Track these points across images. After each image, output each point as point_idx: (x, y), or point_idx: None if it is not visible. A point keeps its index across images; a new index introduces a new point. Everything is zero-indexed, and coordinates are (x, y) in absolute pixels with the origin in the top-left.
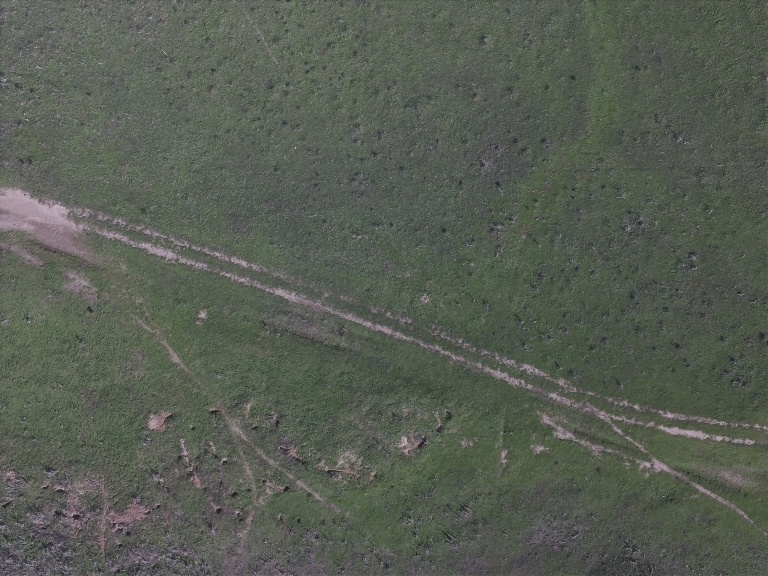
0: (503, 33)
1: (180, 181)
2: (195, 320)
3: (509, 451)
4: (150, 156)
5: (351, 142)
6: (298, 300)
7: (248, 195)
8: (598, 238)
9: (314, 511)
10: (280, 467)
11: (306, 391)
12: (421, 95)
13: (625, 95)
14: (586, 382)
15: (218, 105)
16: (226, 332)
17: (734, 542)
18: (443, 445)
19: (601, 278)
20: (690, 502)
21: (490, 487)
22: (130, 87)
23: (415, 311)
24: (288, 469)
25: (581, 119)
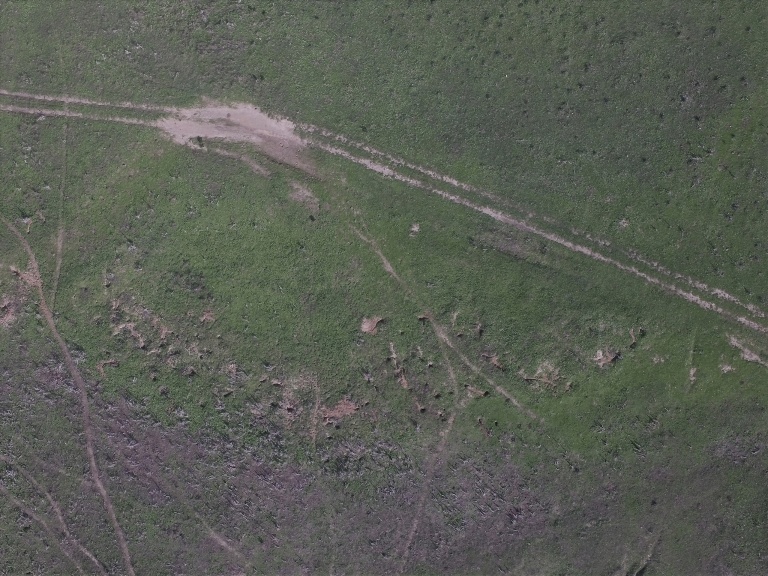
0: None
1: (398, 102)
2: (408, 232)
3: (698, 369)
4: (371, 78)
5: (559, 73)
6: (504, 219)
7: (461, 118)
8: None
9: (512, 416)
10: (482, 373)
11: (509, 304)
12: (627, 31)
13: None
14: None
15: (436, 33)
16: (437, 245)
17: None
18: (636, 360)
19: None
20: None
21: (678, 402)
22: (354, 12)
23: (614, 234)
24: (489, 375)
25: None
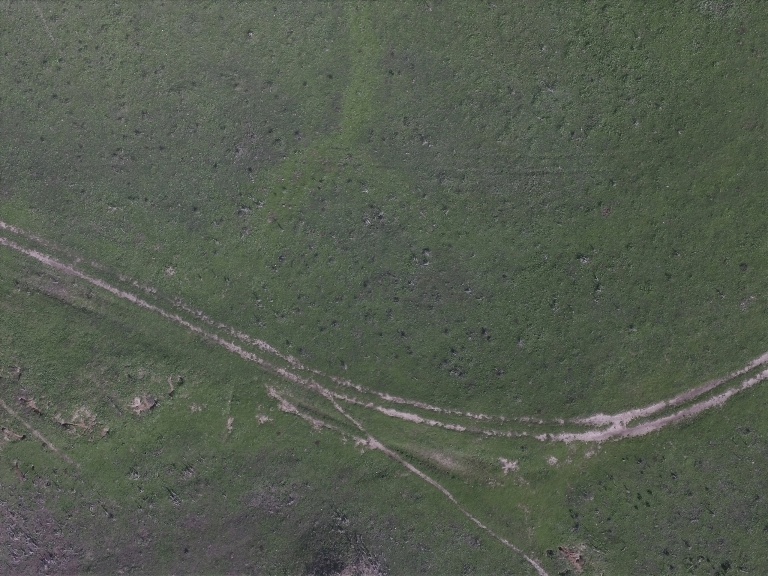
0: (269, 29)
1: None
2: None
3: (235, 419)
4: None
5: (116, 119)
6: (51, 263)
7: (13, 161)
8: (340, 228)
9: (48, 460)
10: (19, 417)
11: (49, 348)
12: (186, 81)
13: (377, 97)
14: (313, 361)
15: None
16: None
17: (437, 520)
18: (174, 408)
19: (339, 265)
20: (400, 480)
21: (215, 451)
22: None
23: (160, 282)
24: (26, 419)
25: (334, 116)
